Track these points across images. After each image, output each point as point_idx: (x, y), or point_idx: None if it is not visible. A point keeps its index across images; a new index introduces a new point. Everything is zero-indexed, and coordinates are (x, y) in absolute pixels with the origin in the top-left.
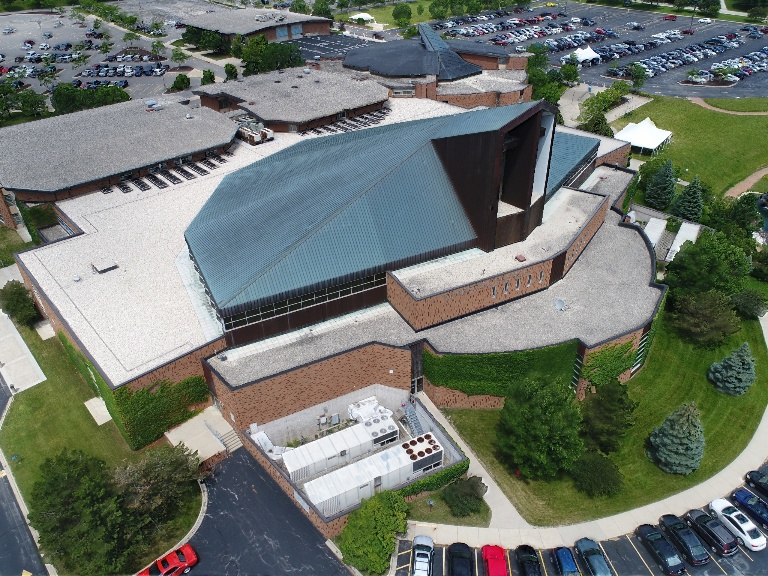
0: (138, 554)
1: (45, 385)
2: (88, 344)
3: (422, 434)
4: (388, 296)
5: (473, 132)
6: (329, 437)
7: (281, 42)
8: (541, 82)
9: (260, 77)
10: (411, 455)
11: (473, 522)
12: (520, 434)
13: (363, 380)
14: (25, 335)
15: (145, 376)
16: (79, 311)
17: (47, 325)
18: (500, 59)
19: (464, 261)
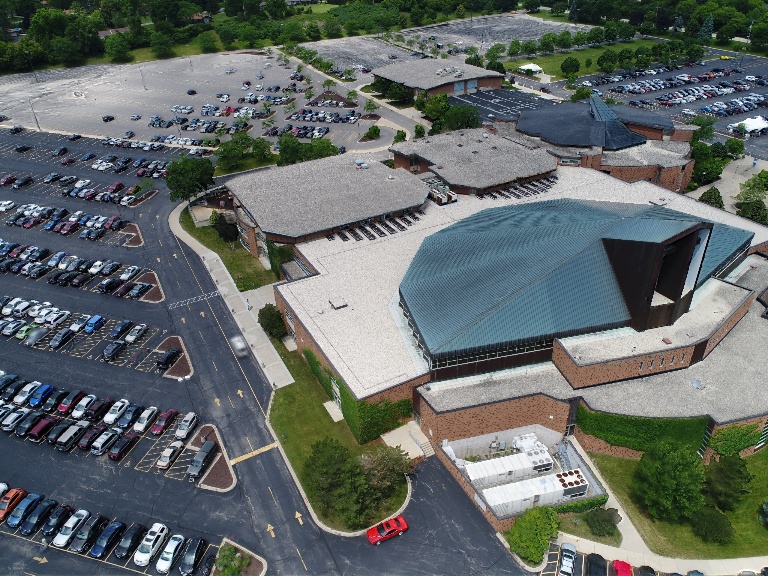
0: (368, 516)
1: (295, 386)
2: (336, 365)
3: (571, 469)
4: (553, 357)
5: (639, 240)
6: (500, 459)
7: (458, 96)
8: (704, 155)
9: (444, 138)
10: (563, 483)
11: (607, 542)
12: (652, 483)
13: (528, 420)
14: (276, 346)
15: (377, 395)
16: (326, 338)
17: (290, 340)
18: (665, 131)
19: (618, 337)
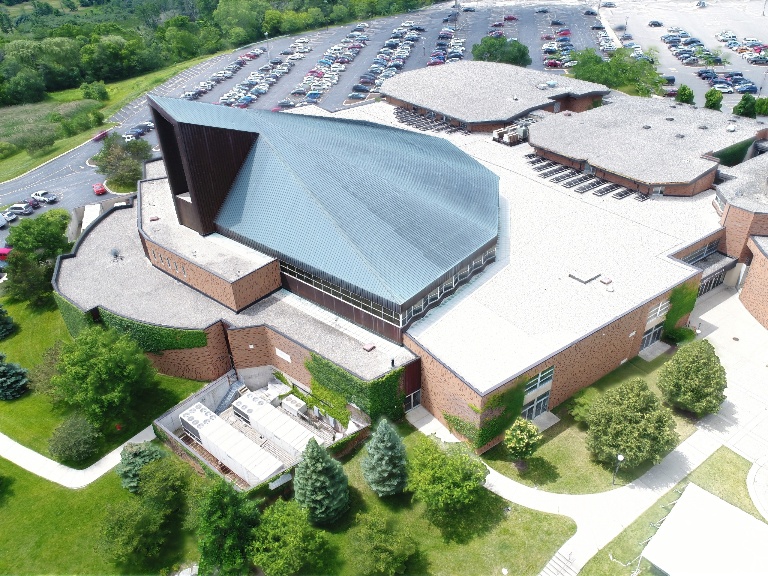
0: None
1: None
2: None
3: None
4: None
5: None
6: None
7: None
8: None
9: (702, 113)
10: None
11: None
12: None
13: None
14: None
15: None
16: None
17: None
18: None
19: None
